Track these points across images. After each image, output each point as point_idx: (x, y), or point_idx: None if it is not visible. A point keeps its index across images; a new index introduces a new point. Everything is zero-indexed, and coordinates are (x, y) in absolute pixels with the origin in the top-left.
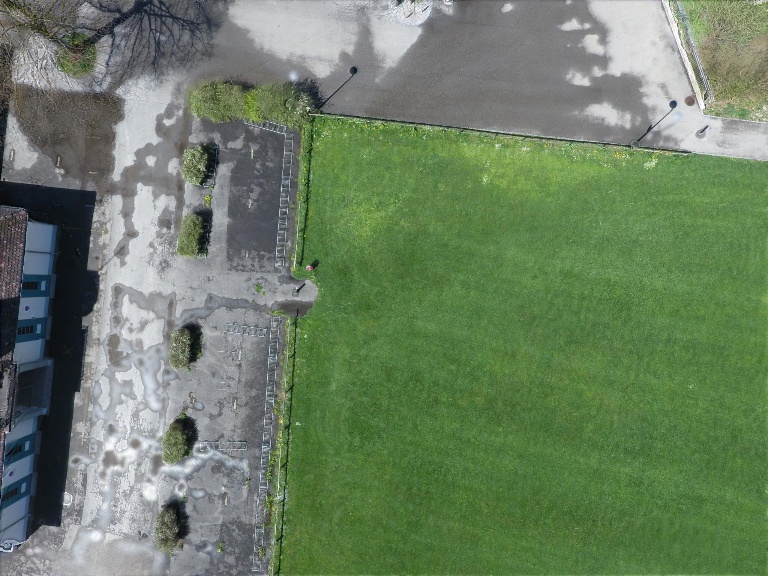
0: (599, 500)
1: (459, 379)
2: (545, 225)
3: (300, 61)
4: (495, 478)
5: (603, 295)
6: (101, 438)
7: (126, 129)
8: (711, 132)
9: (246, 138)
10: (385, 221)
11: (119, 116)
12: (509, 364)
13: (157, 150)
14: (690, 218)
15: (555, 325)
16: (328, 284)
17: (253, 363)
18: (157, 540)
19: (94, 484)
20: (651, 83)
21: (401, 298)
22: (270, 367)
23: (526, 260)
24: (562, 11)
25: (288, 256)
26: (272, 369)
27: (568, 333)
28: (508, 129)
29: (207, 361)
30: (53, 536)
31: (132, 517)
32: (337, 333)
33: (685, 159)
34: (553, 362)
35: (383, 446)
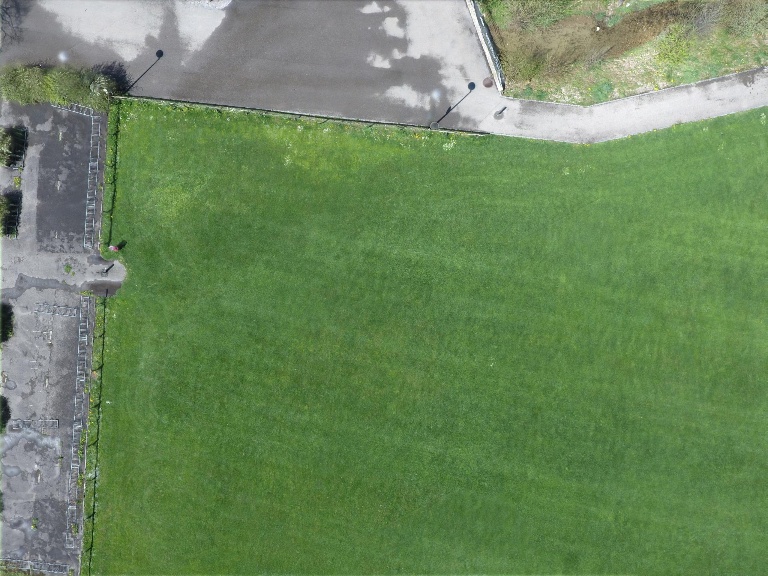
0: (403, 477)
1: (264, 358)
2: (347, 206)
3: (108, 44)
4: (301, 456)
5: (404, 275)
6: None
7: None
8: (509, 113)
9: (54, 120)
10: (191, 202)
11: None
12: (313, 343)
13: None
14: (488, 198)
15: (357, 304)
16: (135, 264)
17: (64, 342)
18: None
19: None
20: (450, 65)
21: (207, 278)
22: (80, 346)
23: (329, 240)
24: None
25: (97, 237)
26: (82, 348)
27: (370, 312)
28: (311, 111)
29: (18, 340)
30: None
31: None
32: (145, 313)
33: (483, 140)
34: (356, 341)
35: (191, 424)
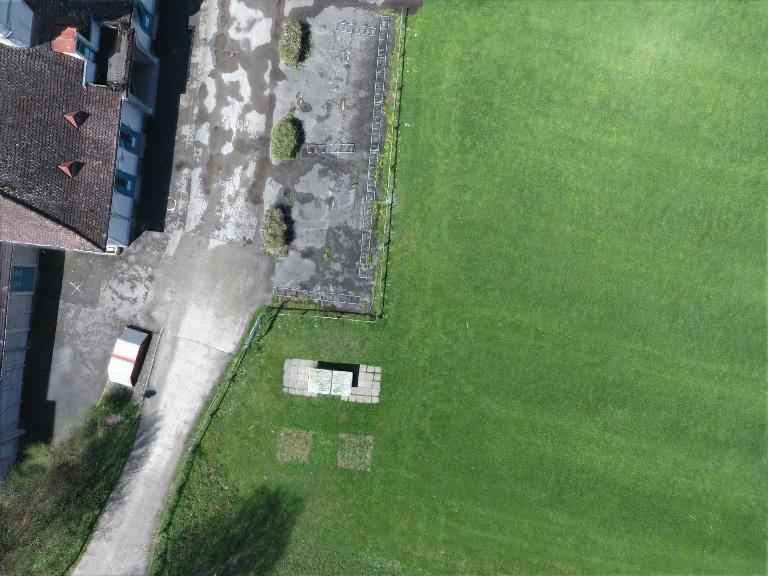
0: (714, 201)
1: (572, 77)
2: None
3: None
4: (608, 179)
5: None
6: (206, 141)
7: None
8: None
9: None
10: None
11: None
12: (623, 62)
13: None
14: None
15: (670, 21)
16: None
17: (362, 64)
18: (266, 235)
19: (198, 189)
20: None
21: None
22: (379, 68)
23: None
24: None
25: None
26: (381, 70)
27: (683, 29)
28: None
29: (315, 61)
30: (156, 242)
31: (237, 222)
32: (448, 31)
33: None
34: (668, 59)
35: (494, 147)
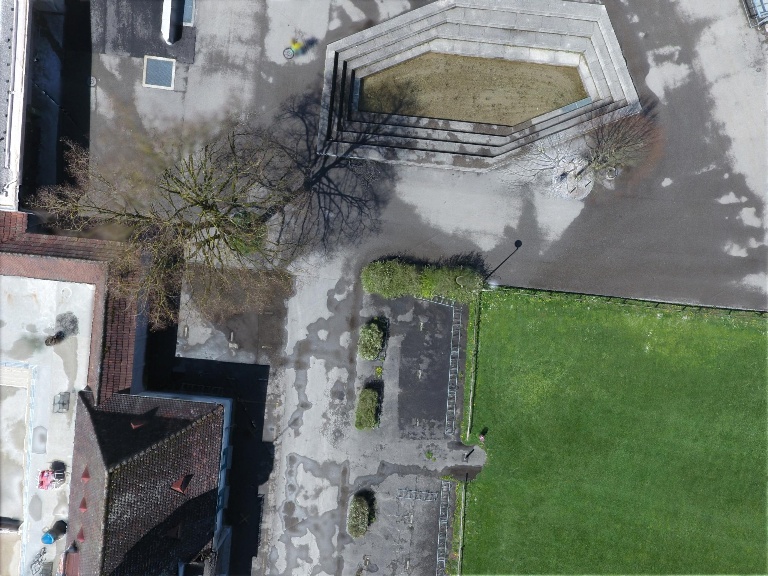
0: None
1: (623, 537)
2: (706, 390)
3: (466, 235)
4: None
5: (761, 456)
6: None
7: (298, 305)
8: None
9: (415, 311)
10: (551, 389)
11: (291, 292)
12: (671, 522)
13: (329, 324)
14: None
15: (715, 485)
16: (497, 450)
17: (424, 526)
18: None
19: None
20: None
21: (568, 462)
22: (441, 529)
23: (687, 424)
24: (721, 185)
25: (457, 423)
26: (443, 531)
27: (727, 492)
28: (669, 298)
29: (380, 525)
30: None
31: None
32: (506, 496)
33: None
34: (713, 519)
35: None
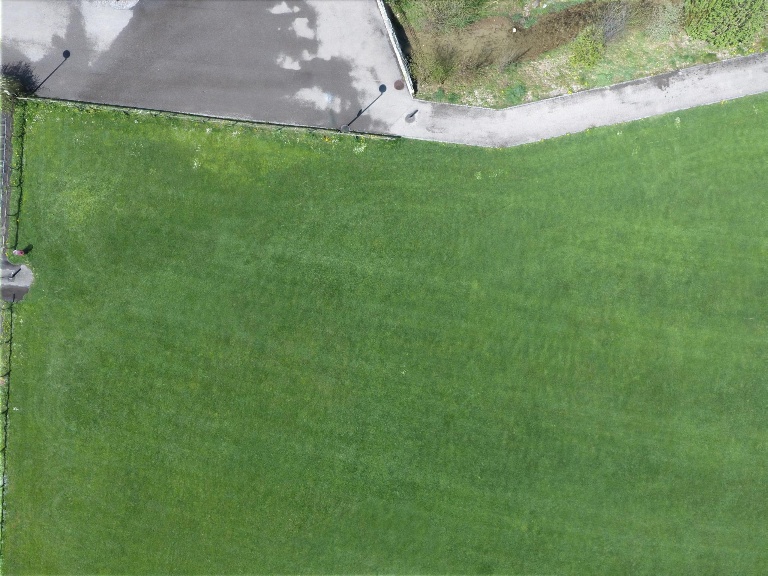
0: (314, 486)
1: (174, 364)
2: (256, 210)
3: (14, 44)
4: (211, 464)
5: (314, 280)
6: None
7: None
8: (420, 116)
9: None
10: (98, 206)
11: None
12: (223, 349)
13: None
14: (399, 203)
15: (267, 310)
16: (42, 269)
17: None
18: None
19: None
20: (360, 67)
21: (114, 283)
22: None
23: (238, 245)
24: None
25: None
26: None
27: (281, 318)
28: (220, 113)
29: None
30: None
31: None
32: (52, 318)
33: (393, 143)
34: (266, 348)
35: (99, 431)
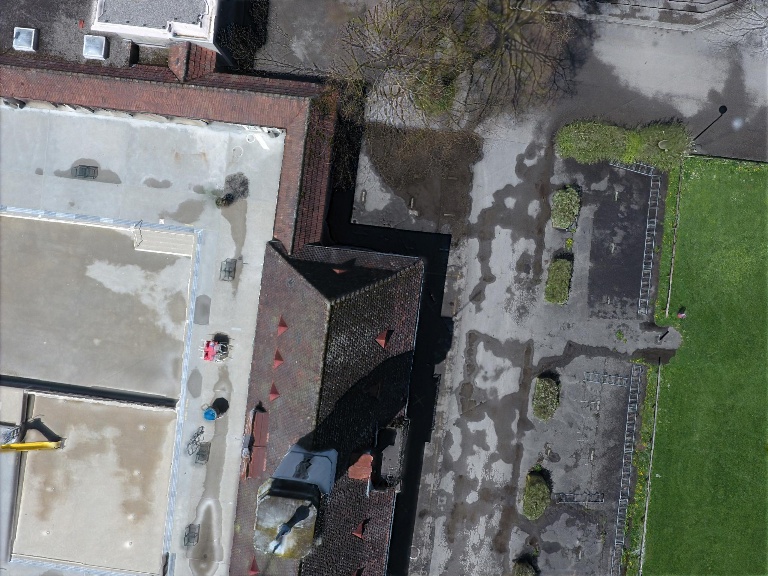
0: None
1: None
2: None
3: (666, 99)
4: None
5: None
6: (451, 490)
7: (484, 170)
8: None
9: (610, 180)
10: (755, 267)
11: (478, 156)
12: None
13: (517, 192)
14: None
15: None
16: (694, 332)
17: (612, 413)
18: None
19: (442, 537)
20: None
21: None
22: (629, 417)
23: None
24: None
25: (651, 302)
26: (632, 419)
27: None
28: None
29: (564, 411)
30: None
31: (482, 571)
32: (702, 383)
33: None
34: None
35: (747, 499)
